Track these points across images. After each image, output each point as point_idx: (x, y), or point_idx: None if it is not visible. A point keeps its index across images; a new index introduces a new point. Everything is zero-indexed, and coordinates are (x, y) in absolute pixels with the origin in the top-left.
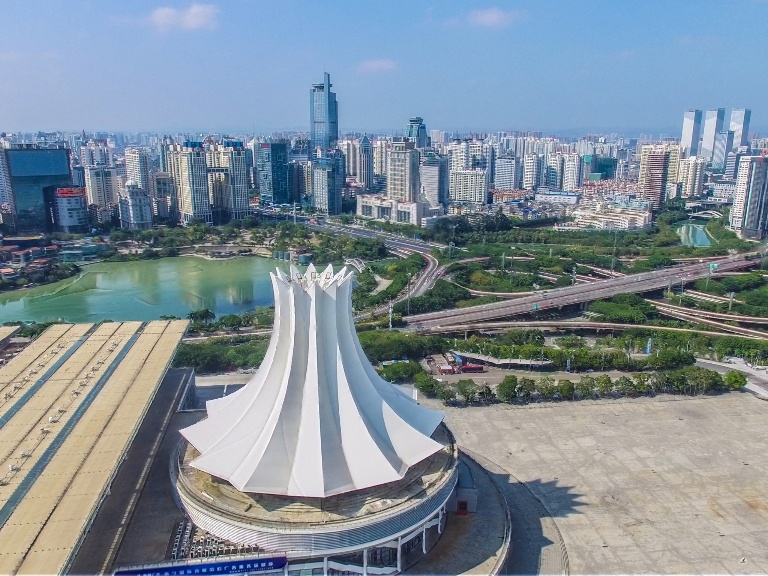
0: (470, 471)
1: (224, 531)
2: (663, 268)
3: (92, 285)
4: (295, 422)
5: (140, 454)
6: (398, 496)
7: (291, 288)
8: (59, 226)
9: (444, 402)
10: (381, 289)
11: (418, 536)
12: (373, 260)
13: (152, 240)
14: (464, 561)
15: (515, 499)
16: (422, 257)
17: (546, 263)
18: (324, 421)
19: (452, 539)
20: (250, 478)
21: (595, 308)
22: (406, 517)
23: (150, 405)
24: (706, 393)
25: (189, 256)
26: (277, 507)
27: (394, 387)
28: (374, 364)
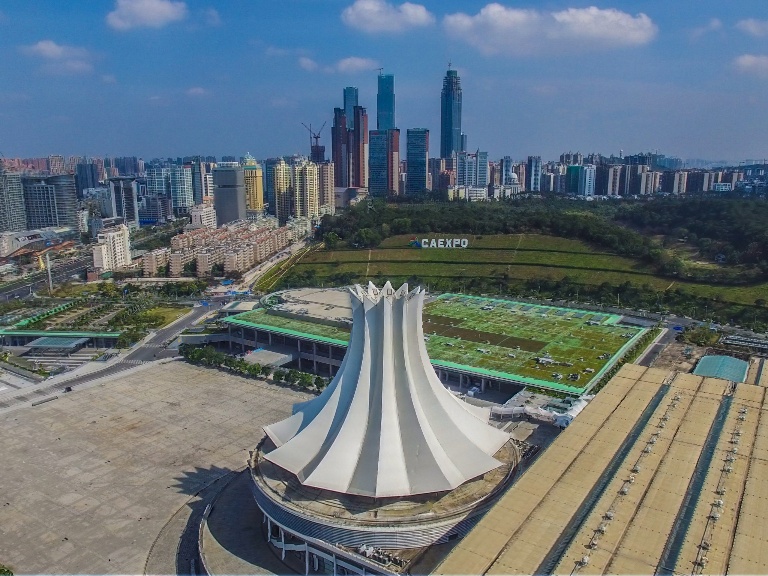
0: None
1: None
2: None
3: None
4: None
5: None
6: None
7: None
8: None
9: None
10: None
11: None
12: None
13: None
14: None
15: None
16: None
17: None
18: None
19: None
20: None
21: None
22: None
23: None
24: None
25: None
26: None
27: None
28: None
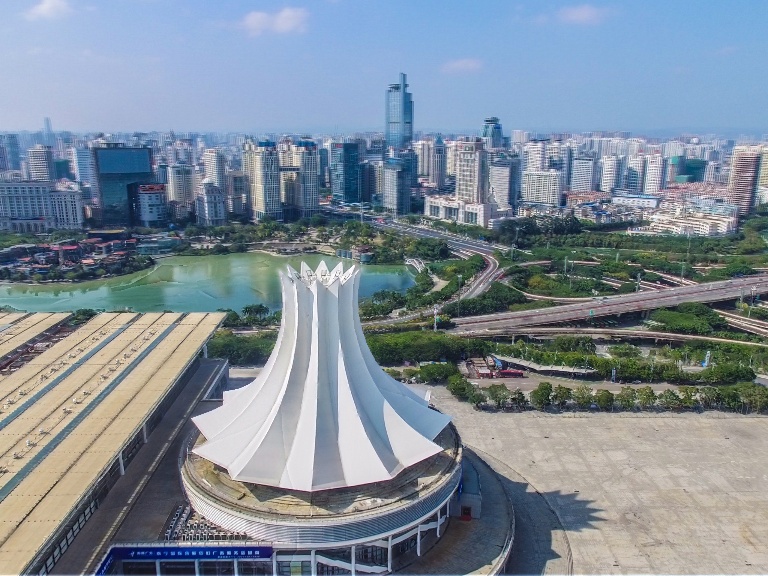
0: (478, 477)
1: (217, 517)
2: (741, 277)
3: (169, 277)
4: (294, 416)
5: (159, 438)
6: (389, 496)
7: (294, 284)
8: (141, 221)
9: (475, 406)
10: (437, 290)
11: (414, 538)
12: (434, 261)
13: (223, 236)
14: (457, 567)
15: (529, 509)
16: (483, 259)
17: (612, 268)
18: (321, 417)
19: (450, 544)
20: (244, 468)
21: (657, 317)
22: (395, 517)
23: (177, 393)
24: (761, 412)
25: (257, 252)
26: (269, 498)
27: (405, 387)
28: (412, 364)
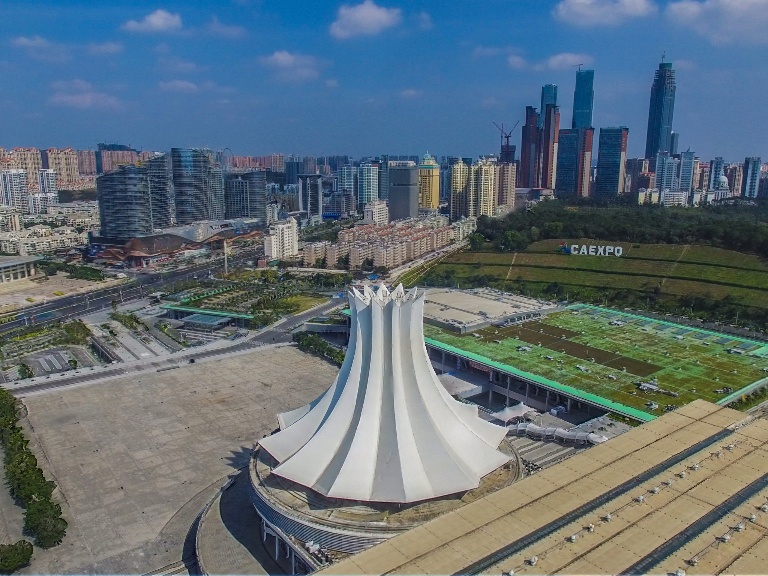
0: None
1: None
2: None
3: None
4: None
5: None
6: None
7: None
8: None
9: (52, 544)
10: None
11: None
12: None
13: None
14: None
15: None
16: None
17: None
18: None
19: None
20: None
21: None
22: None
23: None
24: None
25: None
26: None
27: None
28: None
